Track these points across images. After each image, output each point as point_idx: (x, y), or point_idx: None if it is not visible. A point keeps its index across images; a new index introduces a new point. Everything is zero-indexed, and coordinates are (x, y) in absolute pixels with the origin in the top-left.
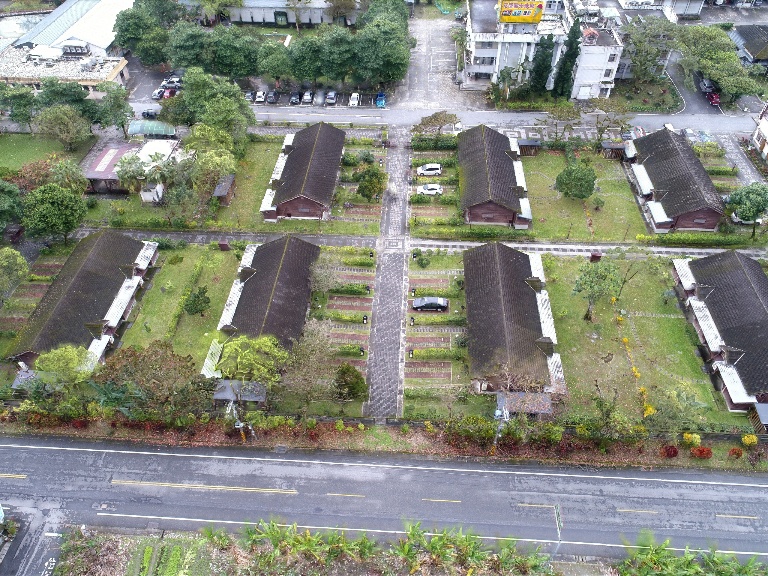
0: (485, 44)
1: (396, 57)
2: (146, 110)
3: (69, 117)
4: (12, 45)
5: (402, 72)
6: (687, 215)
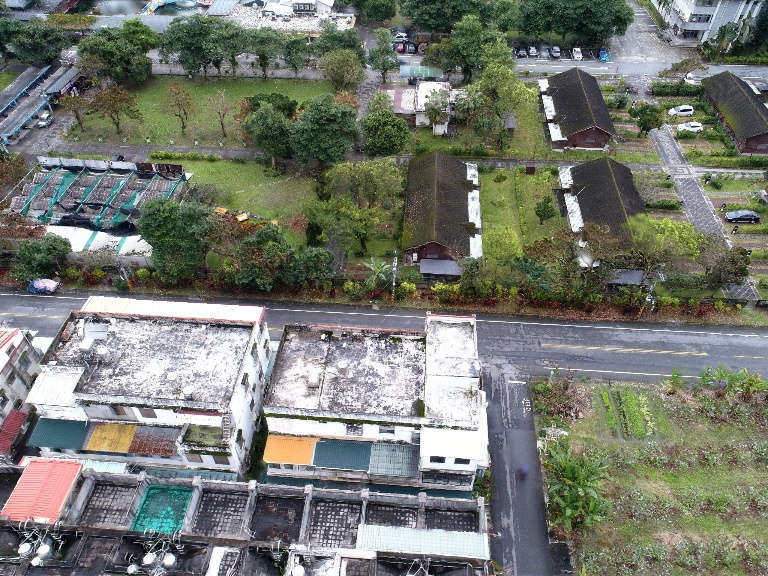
0: (706, 2)
1: (626, 13)
2: (392, 60)
3: (353, 59)
4: (239, 3)
5: (626, 28)
6: None
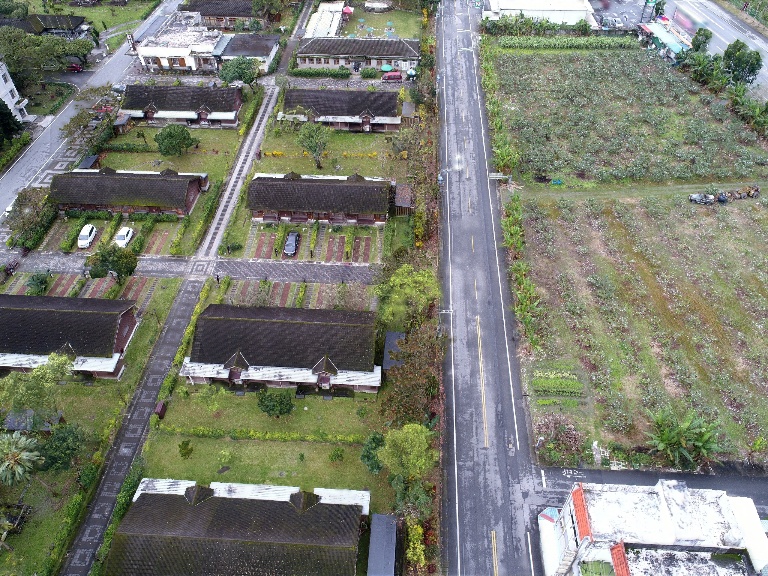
0: None
1: None
2: None
3: None
4: None
5: None
6: (234, 103)
